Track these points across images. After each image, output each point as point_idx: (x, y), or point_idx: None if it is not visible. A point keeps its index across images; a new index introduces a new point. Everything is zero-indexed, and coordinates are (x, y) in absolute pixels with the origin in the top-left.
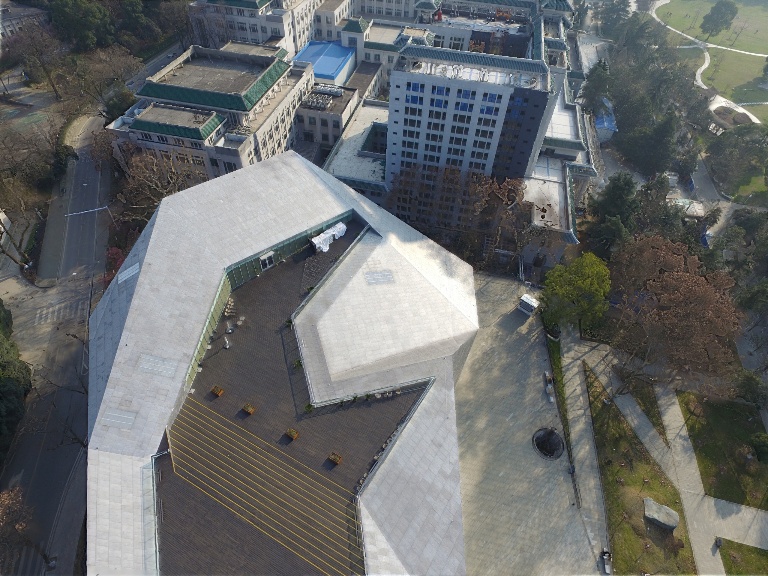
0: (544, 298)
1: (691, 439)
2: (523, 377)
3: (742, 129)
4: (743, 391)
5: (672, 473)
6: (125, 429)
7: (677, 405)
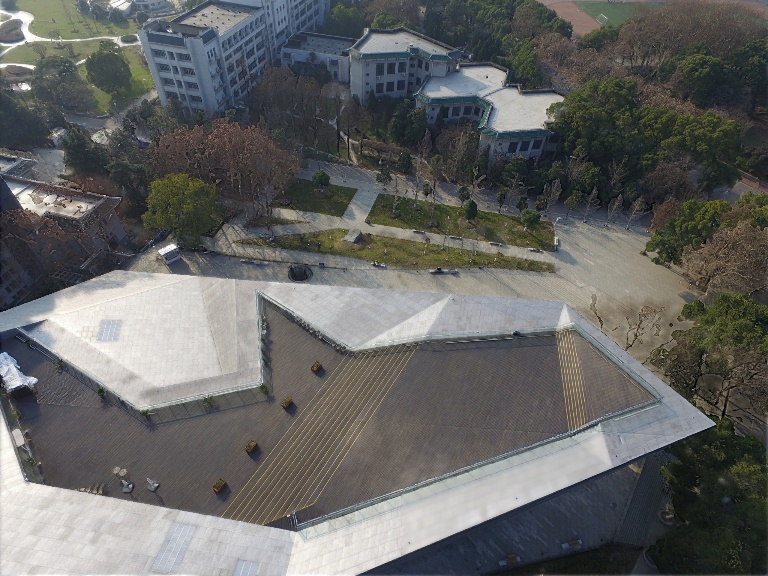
0: (176, 233)
1: (306, 211)
2: (241, 276)
3: (40, 70)
4: (284, 172)
5: (326, 227)
6: (257, 569)
7: (281, 209)
